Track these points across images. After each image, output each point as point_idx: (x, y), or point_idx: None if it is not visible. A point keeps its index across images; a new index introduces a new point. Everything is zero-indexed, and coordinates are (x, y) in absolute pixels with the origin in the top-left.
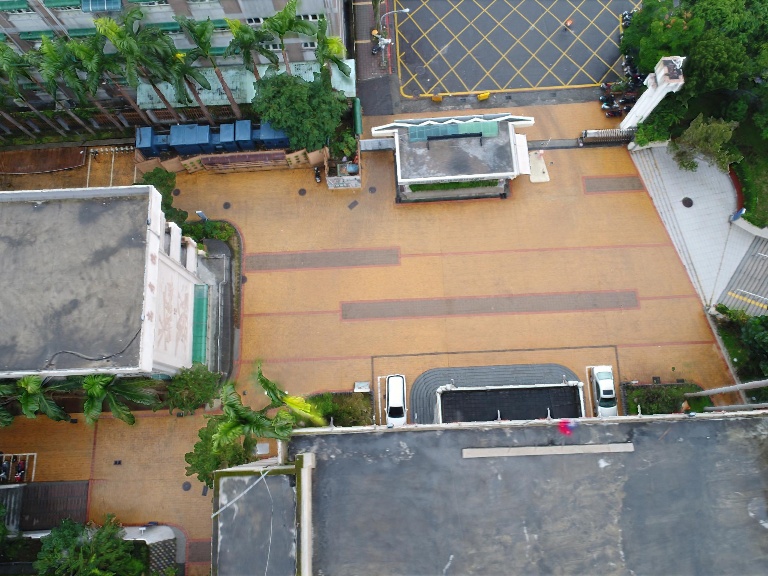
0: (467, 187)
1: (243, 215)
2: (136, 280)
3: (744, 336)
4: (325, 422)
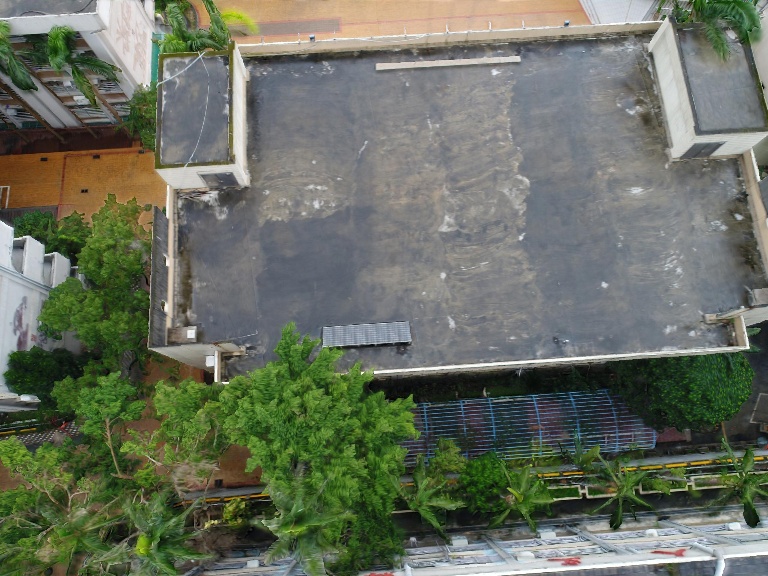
0: None
1: None
2: None
3: None
4: None
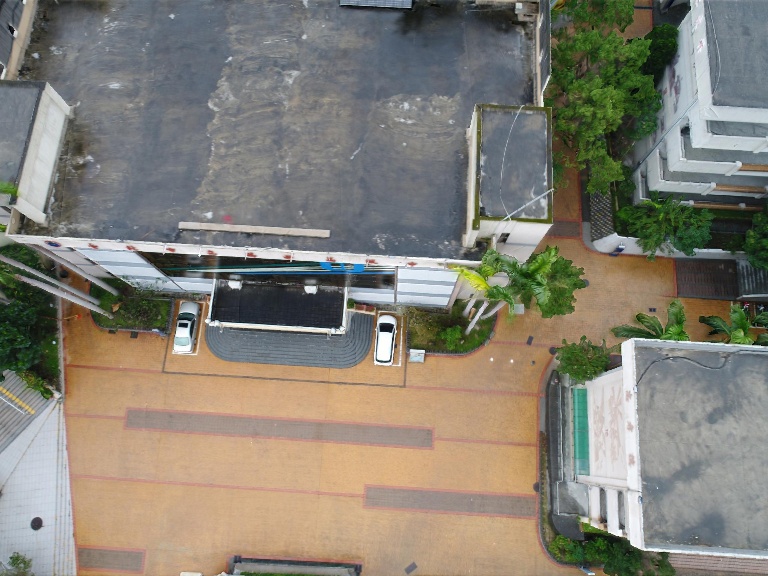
0: (277, 574)
1: (540, 570)
2: (648, 438)
3: (38, 353)
4: (455, 325)
